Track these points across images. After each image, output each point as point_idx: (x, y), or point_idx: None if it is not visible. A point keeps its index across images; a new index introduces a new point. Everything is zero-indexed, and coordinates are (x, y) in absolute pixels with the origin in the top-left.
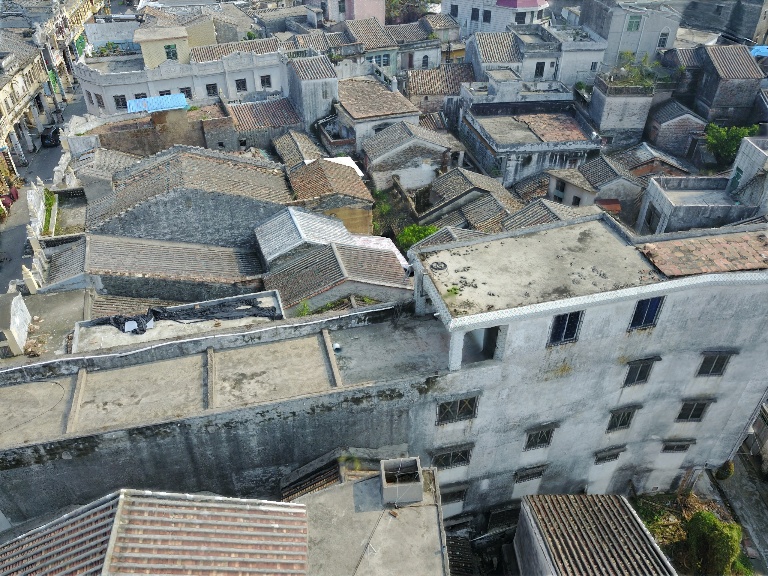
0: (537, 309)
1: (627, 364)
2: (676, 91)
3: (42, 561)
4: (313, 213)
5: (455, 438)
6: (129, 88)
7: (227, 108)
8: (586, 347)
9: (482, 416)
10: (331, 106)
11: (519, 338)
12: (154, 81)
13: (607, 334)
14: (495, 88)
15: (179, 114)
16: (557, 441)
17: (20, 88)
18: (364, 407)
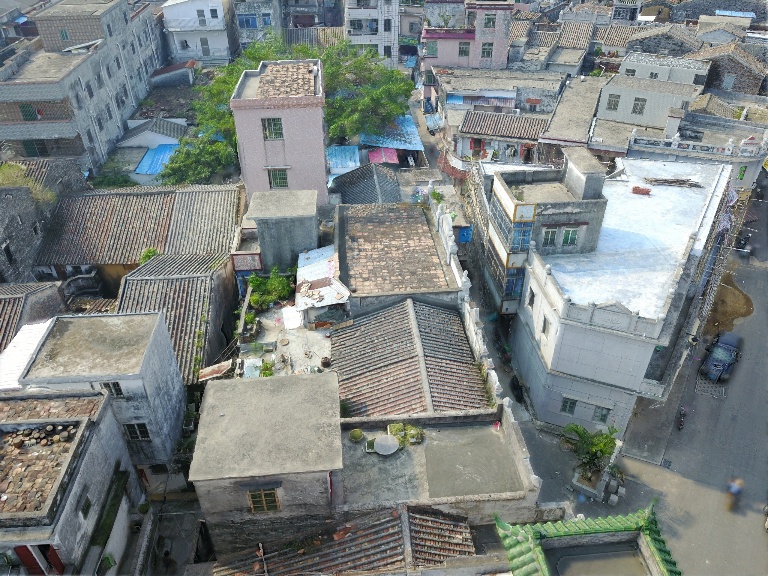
0: None
1: None
2: None
3: None
4: None
5: None
6: None
7: None
8: None
9: None
10: None
11: None
12: None
13: None
14: None
15: None
16: None
17: None
18: None
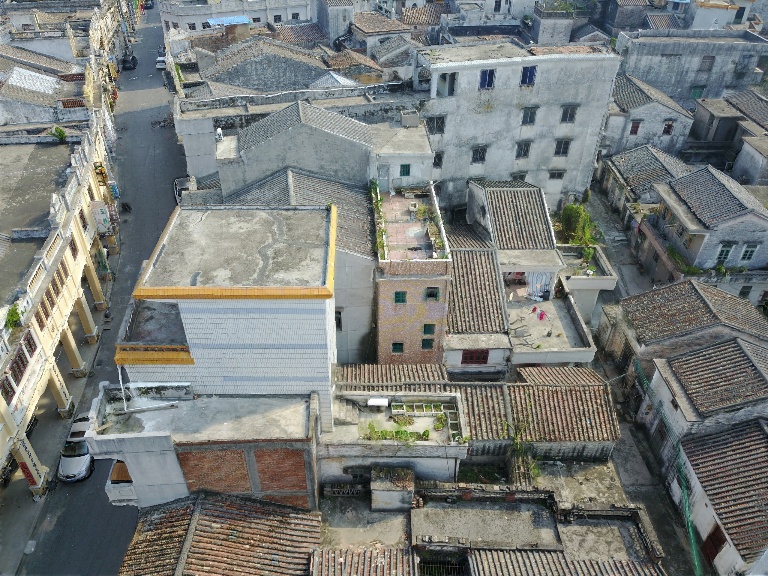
0: (472, 63)
1: (522, 109)
2: (591, 18)
3: (270, 122)
4: (345, 77)
5: (434, 147)
6: (198, 18)
7: (275, 27)
8: (499, 94)
9: (448, 133)
10: (348, 27)
11: (464, 82)
12: (216, 13)
13: (509, 87)
14: (465, 15)
15: (244, 28)
16: (489, 160)
17: (109, 22)
18: (389, 116)
